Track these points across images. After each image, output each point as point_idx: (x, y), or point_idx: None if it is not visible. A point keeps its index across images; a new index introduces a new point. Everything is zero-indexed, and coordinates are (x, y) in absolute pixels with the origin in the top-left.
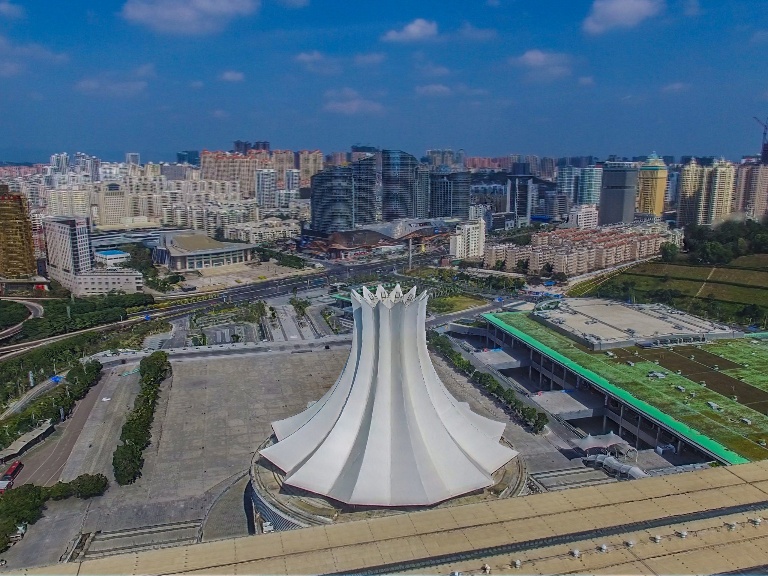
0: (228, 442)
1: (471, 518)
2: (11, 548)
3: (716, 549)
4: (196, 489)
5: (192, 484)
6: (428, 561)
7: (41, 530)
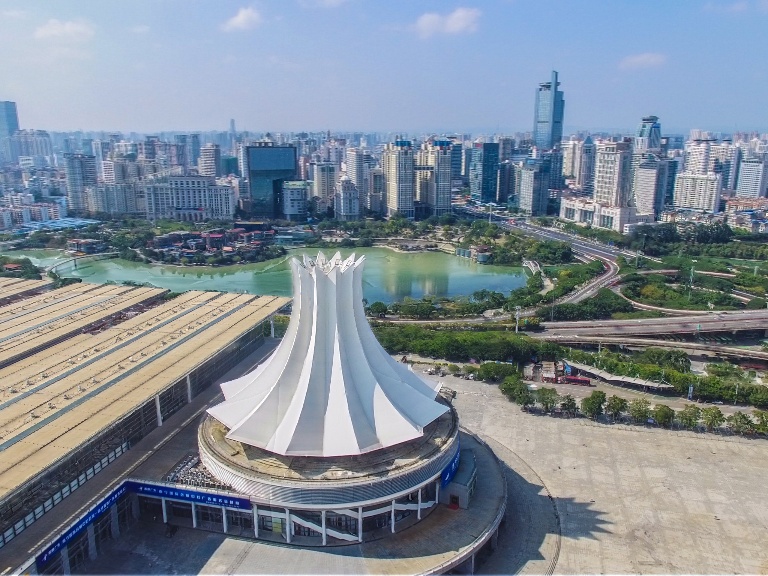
0: (595, 459)
1: (172, 370)
2: (457, 377)
3: (7, 420)
4: (495, 432)
5: (507, 432)
6: (164, 353)
7: (472, 384)
